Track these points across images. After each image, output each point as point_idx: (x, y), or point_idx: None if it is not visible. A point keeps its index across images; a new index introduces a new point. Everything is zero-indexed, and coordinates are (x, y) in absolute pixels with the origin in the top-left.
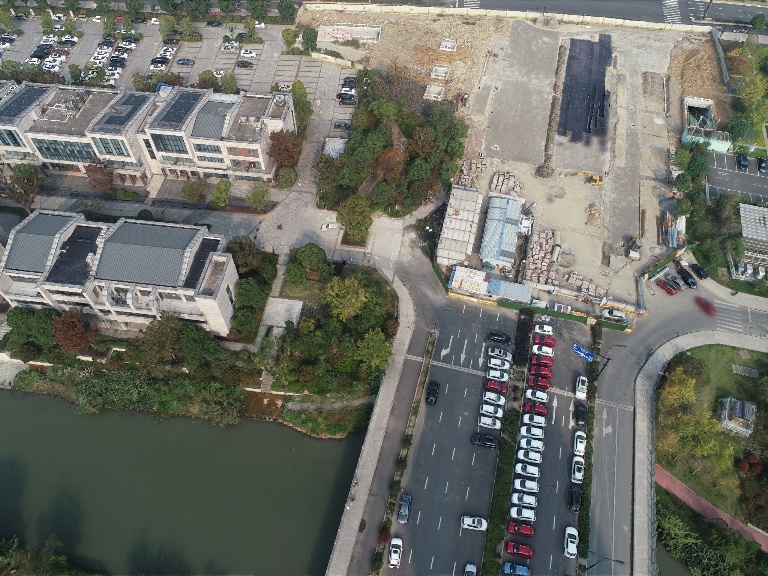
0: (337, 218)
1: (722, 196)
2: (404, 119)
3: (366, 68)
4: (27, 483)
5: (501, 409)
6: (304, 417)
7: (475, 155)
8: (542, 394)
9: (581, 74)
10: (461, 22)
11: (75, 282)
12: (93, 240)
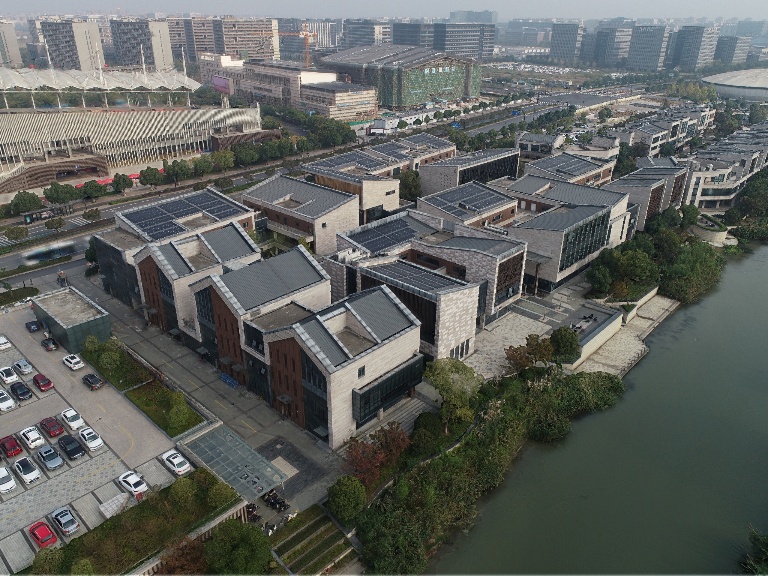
0: (762, 115)
1: (753, 105)
2: None
3: (636, 114)
4: None
5: None
6: None
7: None
8: None
9: (657, 107)
10: None
11: None
12: None
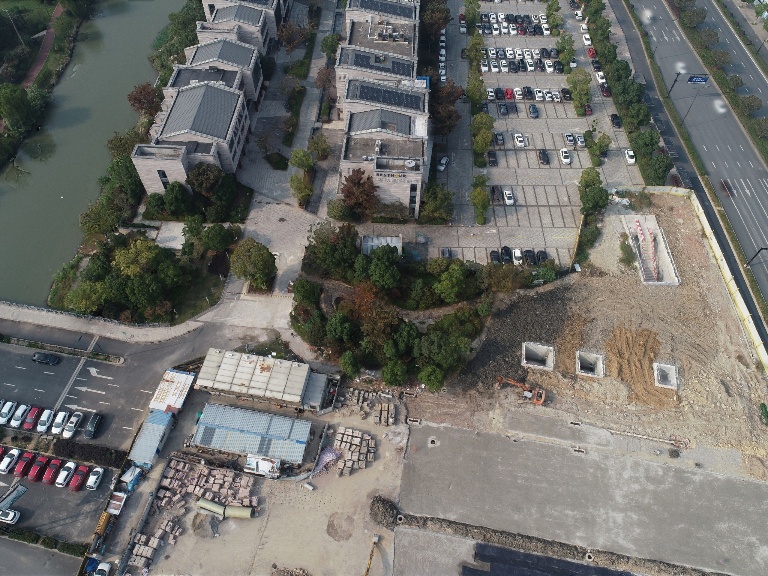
0: None
1: None
2: (454, 313)
3: (557, 266)
4: (72, 128)
5: (5, 421)
6: (64, 266)
7: (414, 413)
8: (5, 464)
9: None
10: (762, 402)
11: (178, 83)
12: None
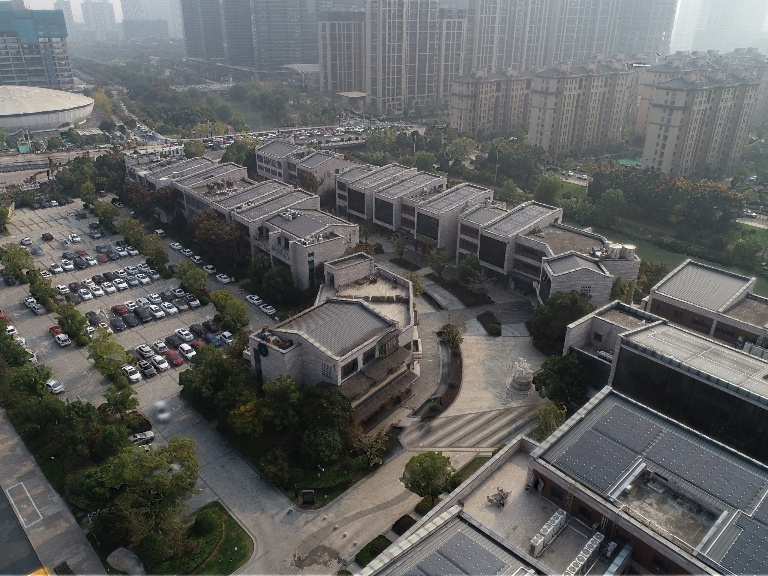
0: None
1: None
2: None
3: None
4: None
5: None
6: None
7: None
8: None
9: None
10: None
11: None
12: None
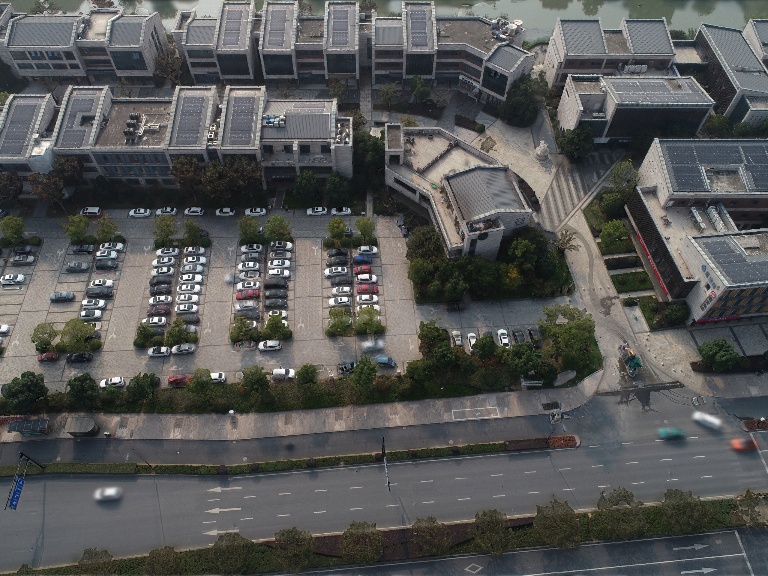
0: None
1: None
2: None
3: None
4: (150, 7)
5: None
6: None
7: None
8: None
9: None
10: None
11: (100, 14)
12: (93, 34)
